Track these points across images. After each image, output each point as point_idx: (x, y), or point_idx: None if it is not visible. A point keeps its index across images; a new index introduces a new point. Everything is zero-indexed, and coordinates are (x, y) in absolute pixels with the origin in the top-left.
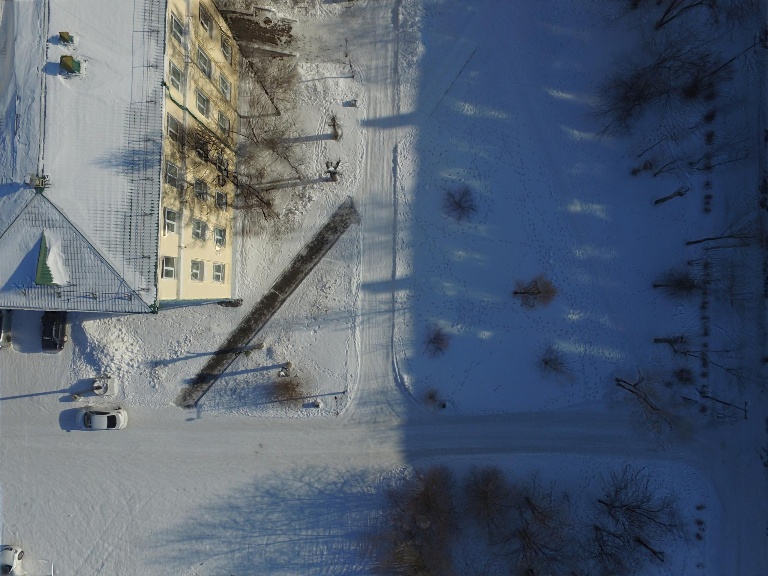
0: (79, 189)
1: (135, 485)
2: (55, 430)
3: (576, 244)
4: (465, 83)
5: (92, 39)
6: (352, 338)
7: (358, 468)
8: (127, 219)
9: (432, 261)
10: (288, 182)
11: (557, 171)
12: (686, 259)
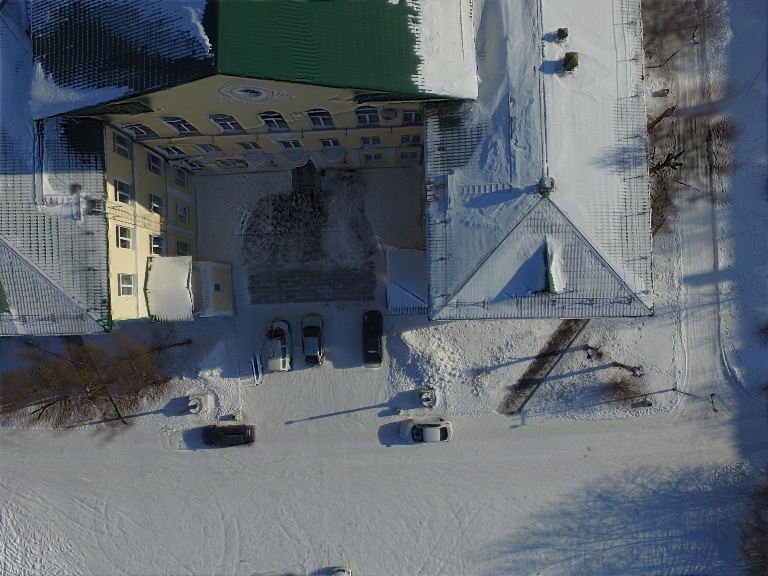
0: (580, 191)
1: (463, 497)
2: (375, 446)
3: None
4: None
5: (580, 34)
6: (678, 333)
7: (692, 466)
8: (624, 220)
9: (754, 250)
10: None
11: None
12: None
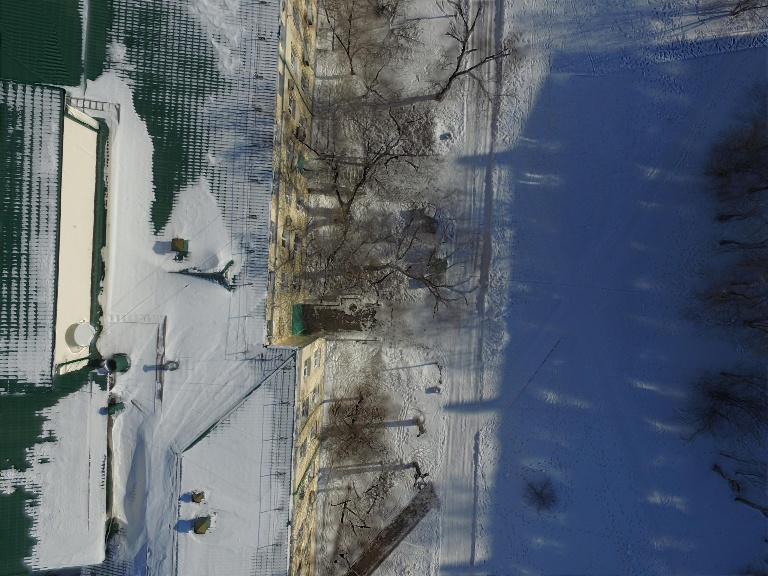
0: None
1: None
2: None
3: (654, 537)
4: (548, 372)
5: (222, 491)
6: None
7: None
8: None
9: (510, 548)
10: (369, 467)
11: (638, 463)
12: (764, 558)
